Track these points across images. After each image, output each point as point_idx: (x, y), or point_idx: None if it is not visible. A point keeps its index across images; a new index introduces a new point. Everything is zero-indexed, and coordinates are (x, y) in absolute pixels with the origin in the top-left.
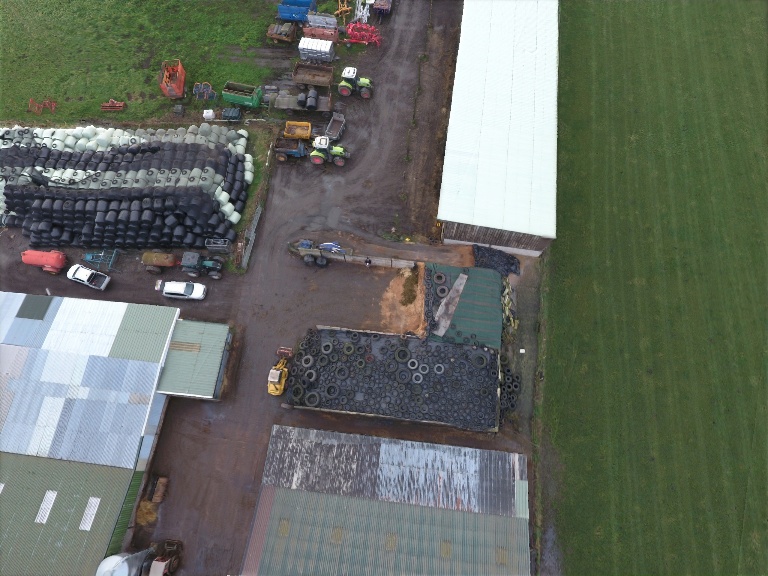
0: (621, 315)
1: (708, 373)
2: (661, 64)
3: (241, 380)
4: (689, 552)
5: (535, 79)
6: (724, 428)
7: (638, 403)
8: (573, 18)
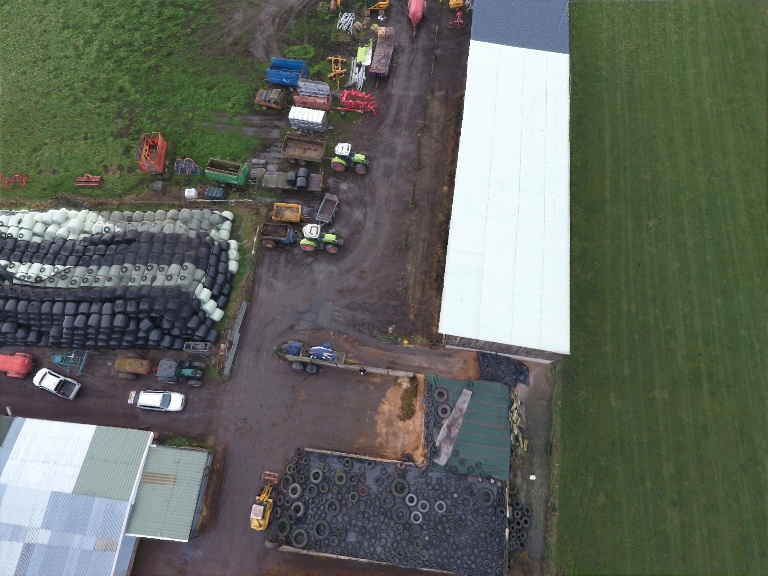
0: (641, 435)
1: (739, 507)
2: (680, 137)
3: (221, 509)
4: None
5: (545, 163)
6: (759, 575)
7: (662, 542)
8: (584, 83)
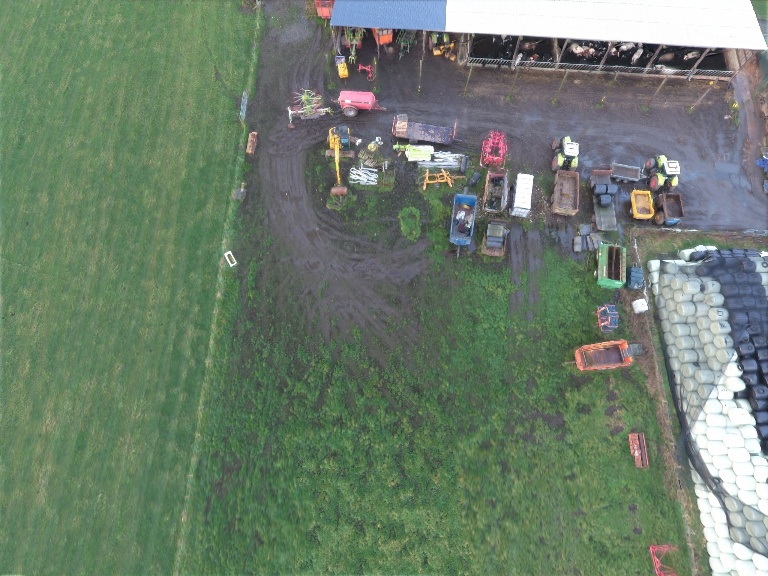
0: None
1: None
2: None
3: None
4: None
5: None
6: None
7: None
8: None
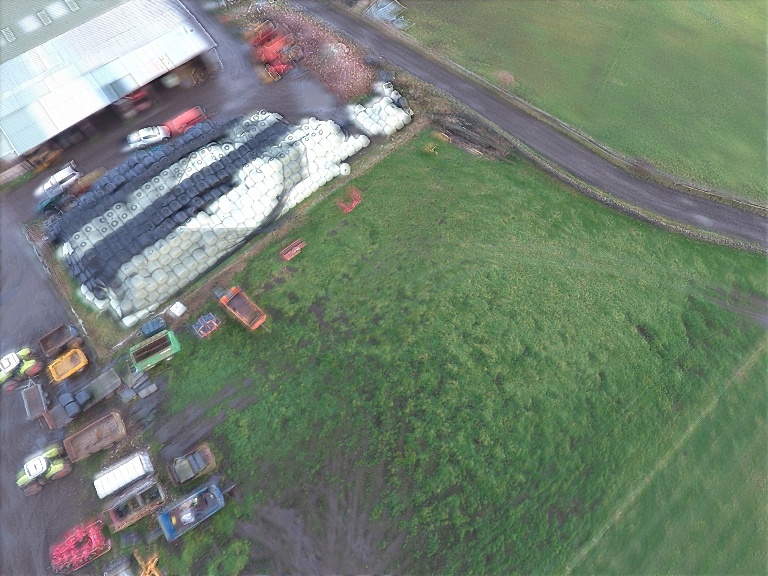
0: None
1: None
2: None
3: None
4: None
5: None
6: None
7: None
8: None
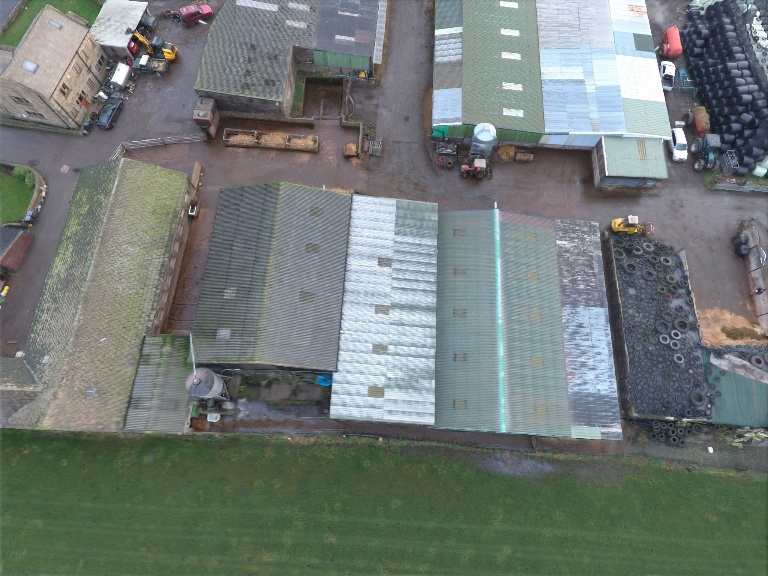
0: None
1: None
2: None
3: (615, 199)
4: None
5: None
6: None
7: None
8: None
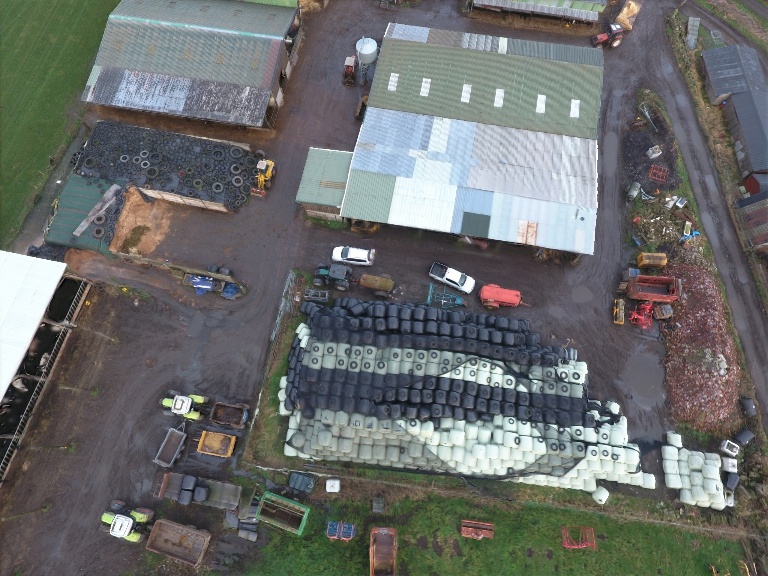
0: None
1: None
2: None
3: (300, 178)
4: (9, 61)
5: None
6: None
7: None
8: None
